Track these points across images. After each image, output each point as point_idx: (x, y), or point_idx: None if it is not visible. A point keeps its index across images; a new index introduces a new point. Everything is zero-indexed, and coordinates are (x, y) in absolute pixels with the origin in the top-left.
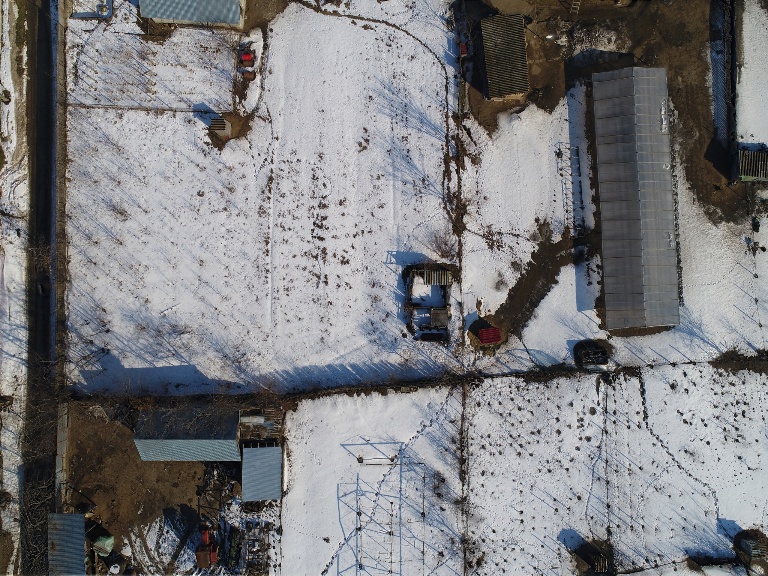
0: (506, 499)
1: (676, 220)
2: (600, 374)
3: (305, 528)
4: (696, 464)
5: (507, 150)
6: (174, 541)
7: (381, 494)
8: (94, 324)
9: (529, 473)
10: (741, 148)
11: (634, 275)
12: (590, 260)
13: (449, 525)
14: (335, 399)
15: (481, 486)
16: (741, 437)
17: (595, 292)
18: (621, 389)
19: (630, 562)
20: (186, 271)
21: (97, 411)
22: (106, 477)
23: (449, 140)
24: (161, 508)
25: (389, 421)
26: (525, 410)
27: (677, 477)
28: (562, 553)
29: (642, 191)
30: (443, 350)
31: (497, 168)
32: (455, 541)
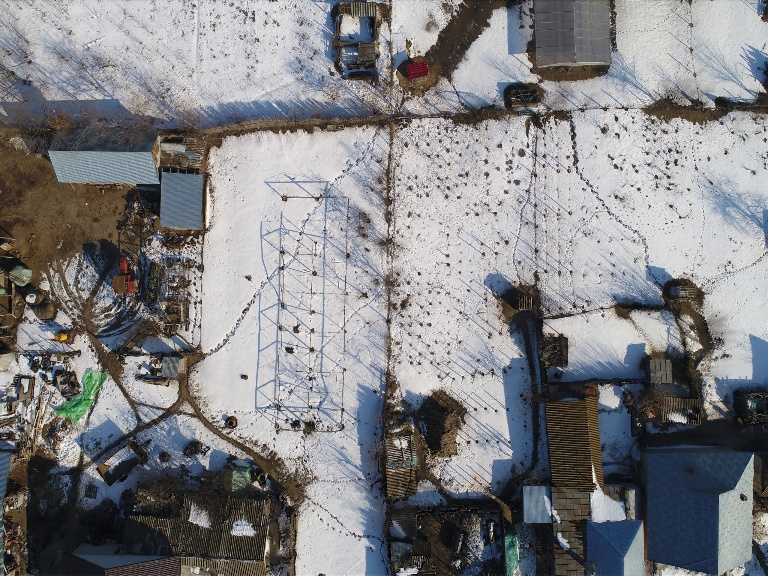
0: (432, 242)
1: None
2: (530, 116)
3: (227, 266)
4: (626, 210)
5: None
6: (93, 277)
7: (305, 233)
8: (16, 55)
9: (456, 216)
10: None
11: (565, 10)
12: (523, 3)
13: (374, 266)
14: (260, 135)
15: (407, 228)
16: (673, 185)
17: (527, 36)
18: (551, 133)
19: (557, 307)
20: (111, 4)
21: (17, 143)
22: (25, 210)
23: None
24: (81, 243)
25: (314, 159)
26: (453, 152)
27: (606, 223)
28: (488, 298)
29: None
30: (371, 89)
31: None
32: (379, 282)
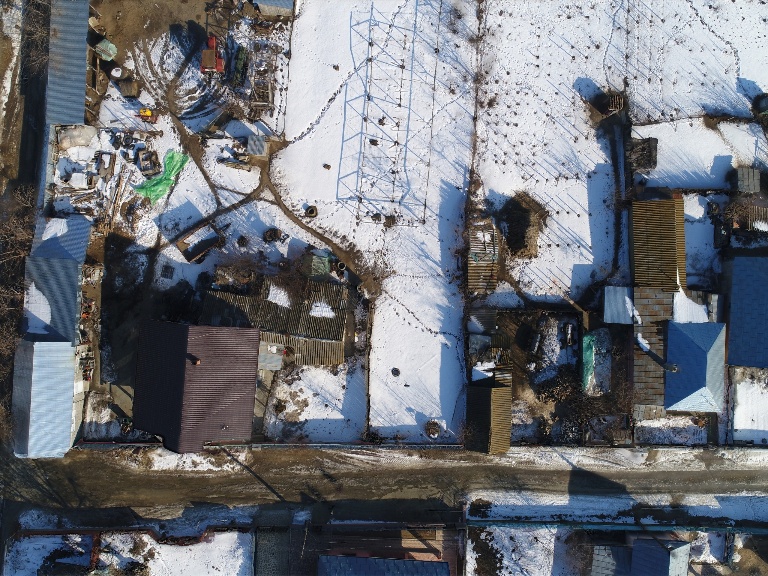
0: (523, 42)
1: None
2: None
3: (315, 54)
4: (720, 21)
5: None
6: (179, 58)
7: (395, 26)
8: None
9: (548, 18)
10: None
11: None
12: None
13: (463, 63)
14: None
15: (498, 26)
16: None
17: None
18: None
19: (645, 114)
20: None
21: None
22: None
23: None
24: (168, 24)
25: None
26: None
27: (699, 32)
28: (576, 102)
29: None
30: None
31: None
32: (468, 79)
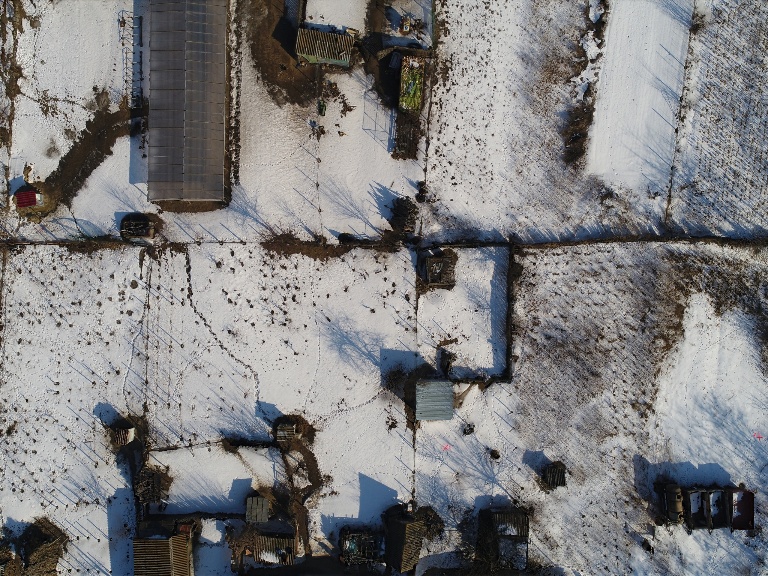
0: (42, 369)
1: (238, 98)
2: (145, 248)
3: None
4: (239, 345)
5: (68, 15)
6: None
7: None
8: None
9: (68, 344)
10: (310, 29)
11: (175, 146)
12: (146, 132)
13: None
14: None
15: (17, 354)
16: (288, 321)
17: None
18: (167, 264)
19: (164, 440)
20: None
21: None
22: None
23: (7, 0)
24: None
25: None
26: (67, 280)
27: (218, 357)
28: (97, 427)
29: (189, 61)
30: None
31: (56, 33)
32: None
